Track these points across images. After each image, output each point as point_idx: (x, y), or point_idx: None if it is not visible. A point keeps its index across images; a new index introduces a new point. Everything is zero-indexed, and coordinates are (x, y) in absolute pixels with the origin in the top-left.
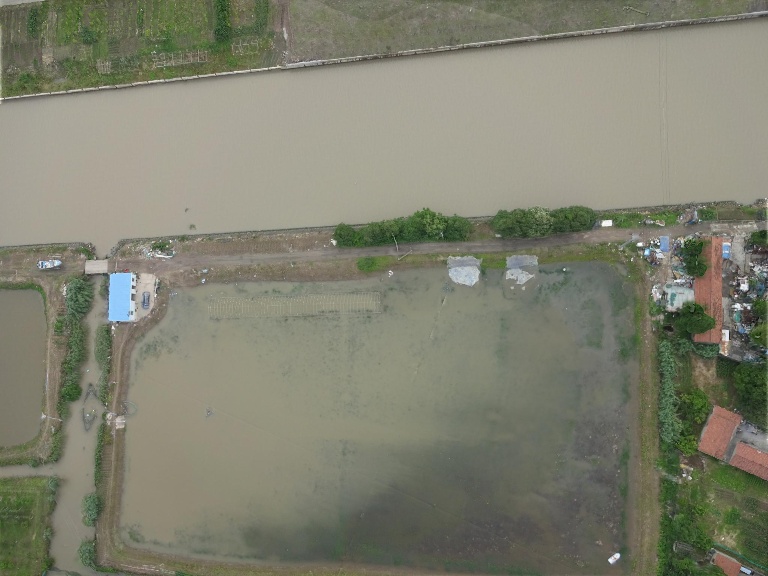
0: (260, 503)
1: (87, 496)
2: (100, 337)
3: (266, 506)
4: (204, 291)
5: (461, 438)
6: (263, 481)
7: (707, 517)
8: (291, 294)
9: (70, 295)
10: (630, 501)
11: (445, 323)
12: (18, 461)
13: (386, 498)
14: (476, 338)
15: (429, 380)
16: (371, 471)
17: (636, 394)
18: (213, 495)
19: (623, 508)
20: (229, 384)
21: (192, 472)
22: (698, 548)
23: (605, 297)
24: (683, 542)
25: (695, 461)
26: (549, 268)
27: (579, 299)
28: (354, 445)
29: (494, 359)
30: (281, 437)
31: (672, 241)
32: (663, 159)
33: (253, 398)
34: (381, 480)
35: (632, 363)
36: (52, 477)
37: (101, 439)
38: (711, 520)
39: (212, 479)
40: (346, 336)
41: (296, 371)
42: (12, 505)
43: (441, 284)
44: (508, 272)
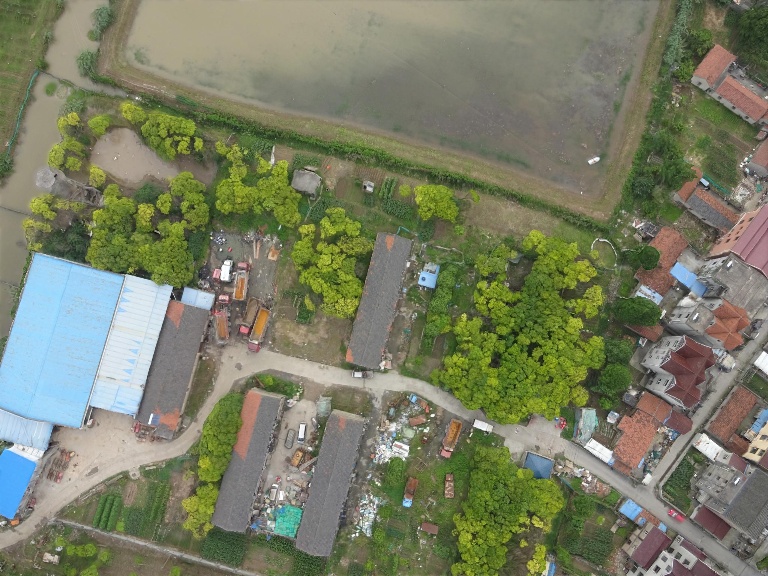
0: (276, 52)
1: None
2: None
3: (281, 56)
4: None
5: (484, 33)
6: (284, 33)
7: (683, 138)
8: None
9: None
10: (620, 116)
11: None
12: None
13: (400, 71)
14: None
15: None
16: (392, 45)
17: (650, 28)
18: (230, 36)
19: (613, 121)
20: None
21: (214, 11)
22: None
23: None
24: (657, 155)
25: (686, 91)
26: None
27: None
28: (381, 19)
29: None
30: None
31: None
32: None
33: None
34: (399, 55)
35: (654, 1)
36: None
37: None
38: (686, 142)
39: (233, 21)
40: None
41: None
42: (15, 2)
43: None
44: None
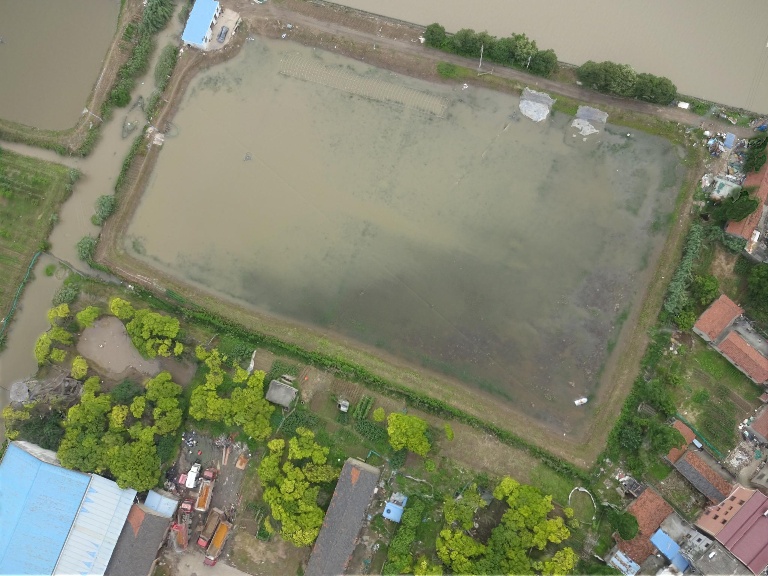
0: (268, 254)
1: (104, 195)
2: (166, 54)
3: (273, 258)
4: (281, 46)
5: (478, 254)
6: (278, 235)
7: (679, 390)
8: (364, 74)
9: (151, 4)
10: (614, 357)
11: (500, 147)
12: (47, 144)
13: (389, 286)
14: (524, 170)
15: (467, 193)
16: (384, 257)
17: (654, 265)
18: (226, 233)
19: (605, 361)
20: (276, 138)
21: (213, 206)
22: (661, 413)
23: (657, 171)
24: (649, 405)
25: (686, 339)
26: (615, 129)
27: (632, 165)
28: (376, 230)
29: (534, 194)
30: (309, 201)
31: (737, 140)
32: (763, 50)
33: (295, 158)
34: (390, 268)
35: (660, 237)
36: (75, 169)
37: (136, 148)
38: (681, 394)
39: (230, 218)
40: (403, 130)
41: (344, 146)
42: (28, 182)
43: (509, 111)
44: (575, 120)
